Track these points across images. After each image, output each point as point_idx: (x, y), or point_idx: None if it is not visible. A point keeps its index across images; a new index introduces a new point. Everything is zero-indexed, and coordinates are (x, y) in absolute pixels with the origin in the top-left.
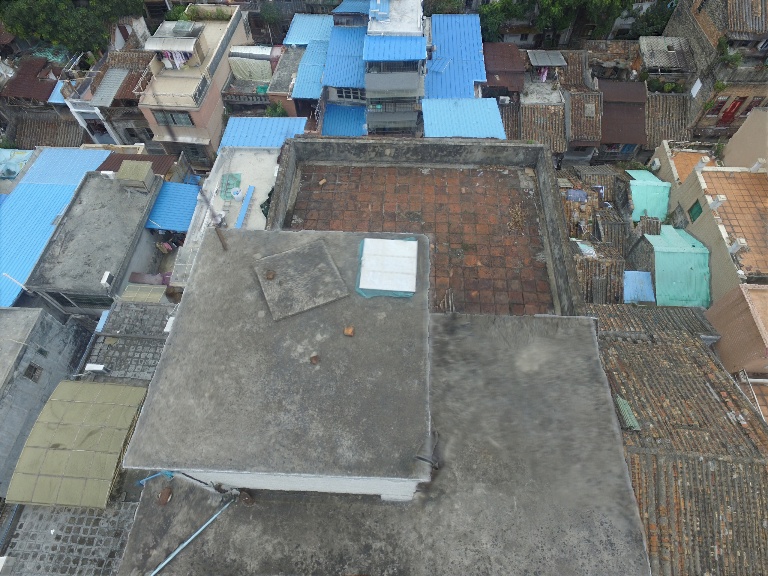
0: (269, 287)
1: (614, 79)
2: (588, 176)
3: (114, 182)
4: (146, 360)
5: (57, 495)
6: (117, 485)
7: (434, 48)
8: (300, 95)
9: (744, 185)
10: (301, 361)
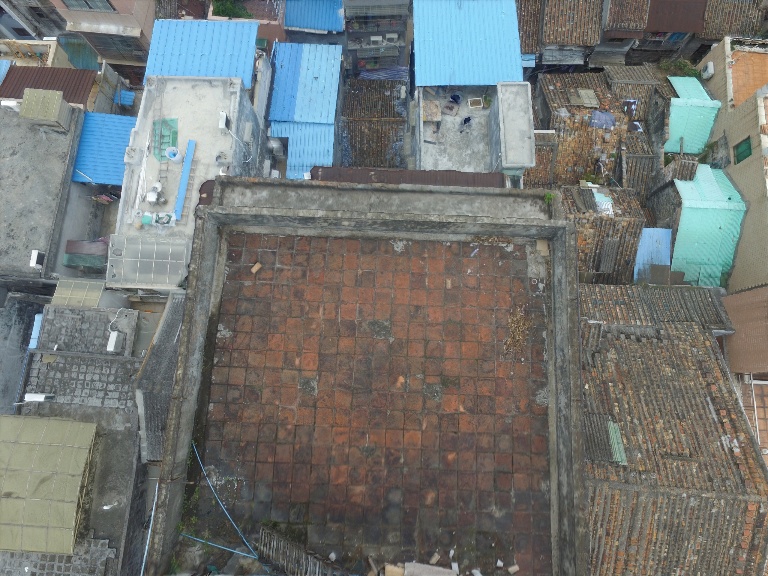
0: None
1: None
2: (620, 86)
3: None
4: (92, 383)
5: (21, 542)
6: (83, 522)
7: None
8: None
9: None
10: None
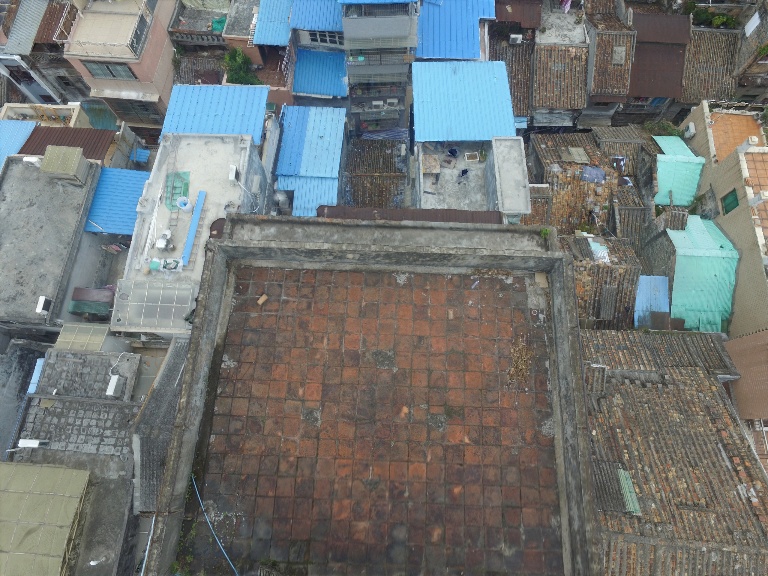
0: None
1: (652, 5)
2: (608, 144)
3: None
4: (89, 428)
5: None
6: None
7: None
8: (264, 40)
9: None
10: None
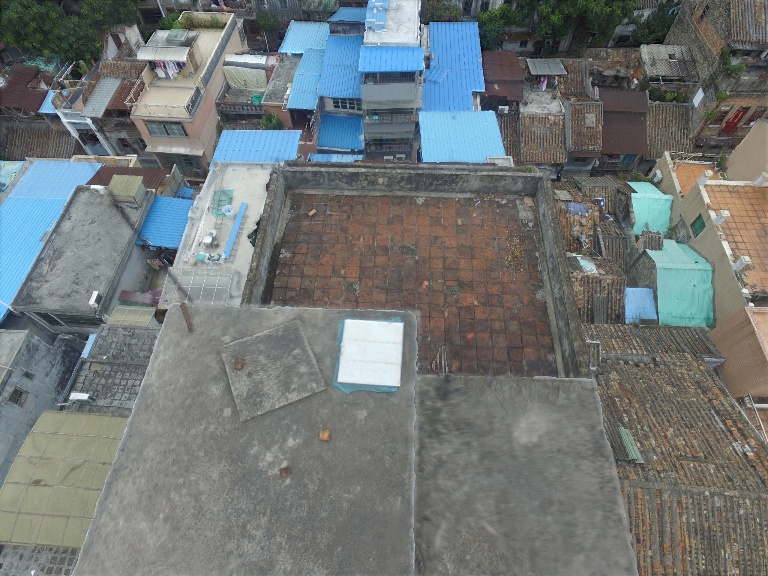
0: (237, 379)
1: (615, 87)
2: (588, 188)
3: (104, 197)
4: (133, 388)
5: (38, 534)
6: None
7: (432, 57)
8: (295, 106)
9: (748, 199)
10: (270, 473)
